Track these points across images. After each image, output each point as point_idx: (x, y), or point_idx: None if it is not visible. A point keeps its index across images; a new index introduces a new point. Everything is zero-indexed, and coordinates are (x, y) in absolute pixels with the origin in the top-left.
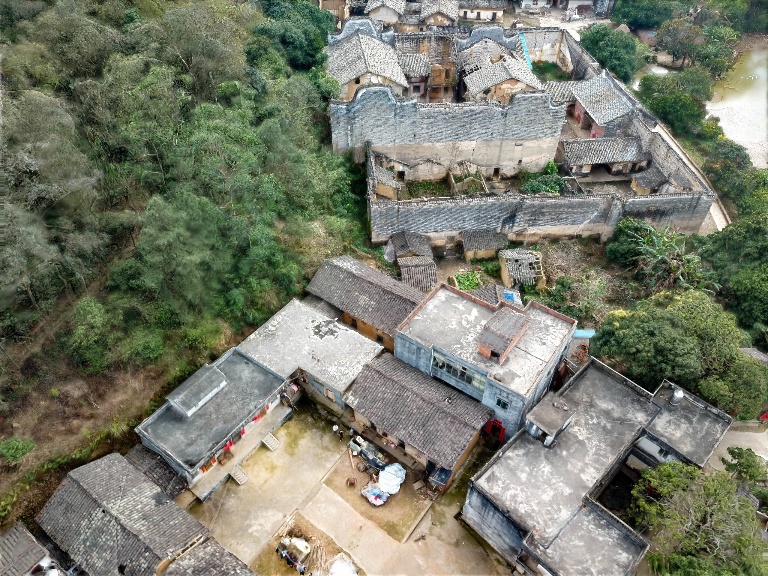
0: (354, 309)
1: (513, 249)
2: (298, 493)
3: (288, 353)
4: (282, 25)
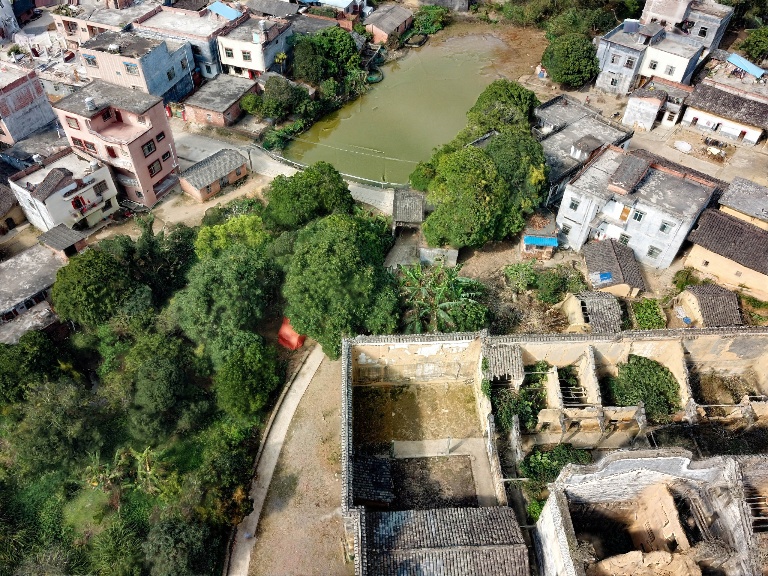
0: (761, 229)
1: (606, 329)
2: (729, 173)
3: None
4: None
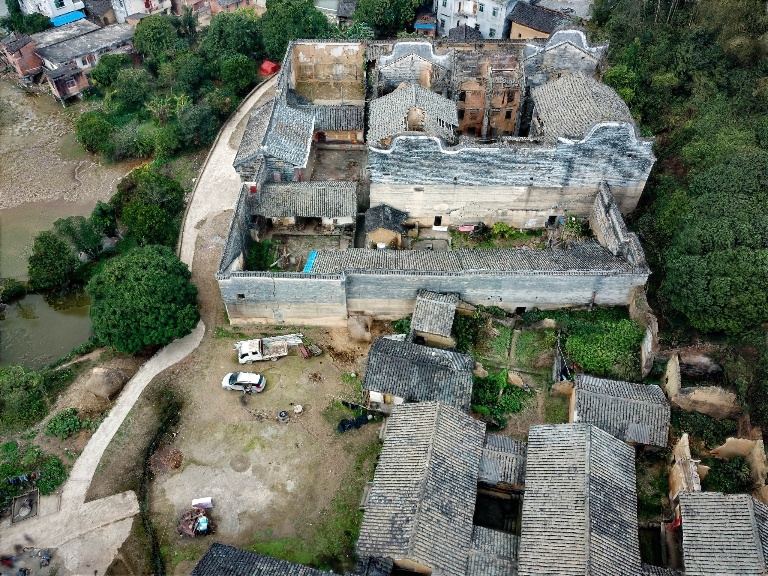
0: None
1: None
2: None
3: (584, 5)
4: (741, 171)
